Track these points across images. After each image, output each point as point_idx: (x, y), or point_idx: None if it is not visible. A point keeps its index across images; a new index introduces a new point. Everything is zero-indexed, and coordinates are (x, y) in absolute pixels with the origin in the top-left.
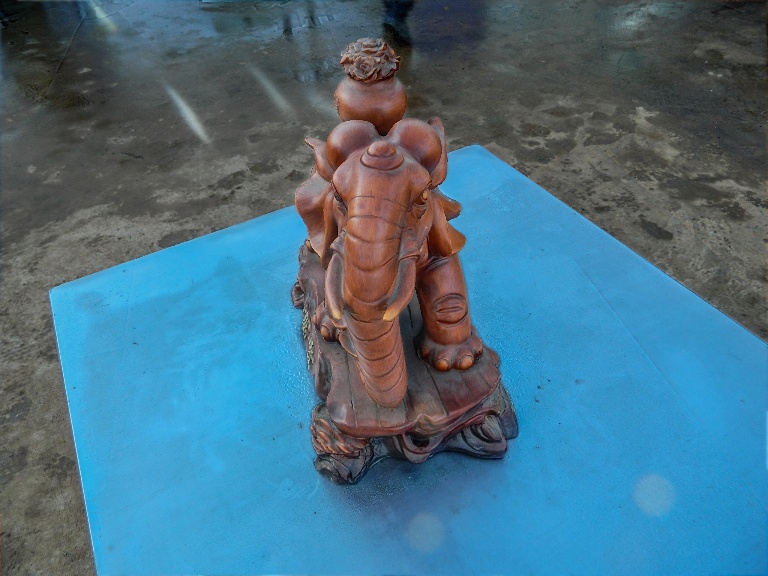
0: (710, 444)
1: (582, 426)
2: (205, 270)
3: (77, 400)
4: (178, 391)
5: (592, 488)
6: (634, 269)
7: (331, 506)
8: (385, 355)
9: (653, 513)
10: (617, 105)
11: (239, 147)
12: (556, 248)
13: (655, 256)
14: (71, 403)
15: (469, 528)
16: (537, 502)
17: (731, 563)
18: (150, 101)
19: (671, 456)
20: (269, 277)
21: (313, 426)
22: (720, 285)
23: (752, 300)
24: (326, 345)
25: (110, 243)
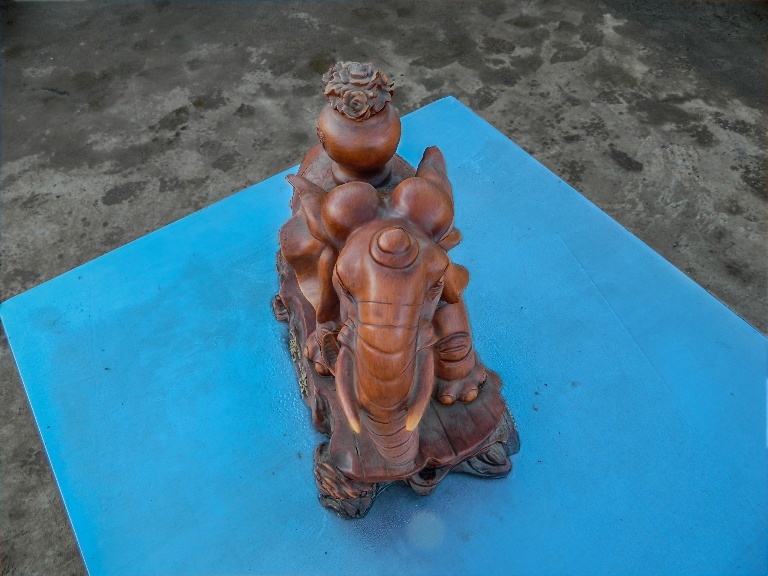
0: (703, 444)
1: (581, 435)
2: (171, 272)
3: (54, 442)
4: (163, 424)
5: (594, 502)
6: (623, 247)
7: (341, 544)
8: (403, 442)
9: (653, 523)
10: (584, 12)
11: (177, 77)
12: (543, 226)
13: (626, 190)
14: (48, 446)
15: (480, 555)
16: (543, 521)
17: (725, 569)
18: (65, 19)
19: (667, 460)
20: (243, 278)
21: (317, 470)
22: (689, 220)
23: (719, 235)
24: (321, 380)
25: (48, 203)
